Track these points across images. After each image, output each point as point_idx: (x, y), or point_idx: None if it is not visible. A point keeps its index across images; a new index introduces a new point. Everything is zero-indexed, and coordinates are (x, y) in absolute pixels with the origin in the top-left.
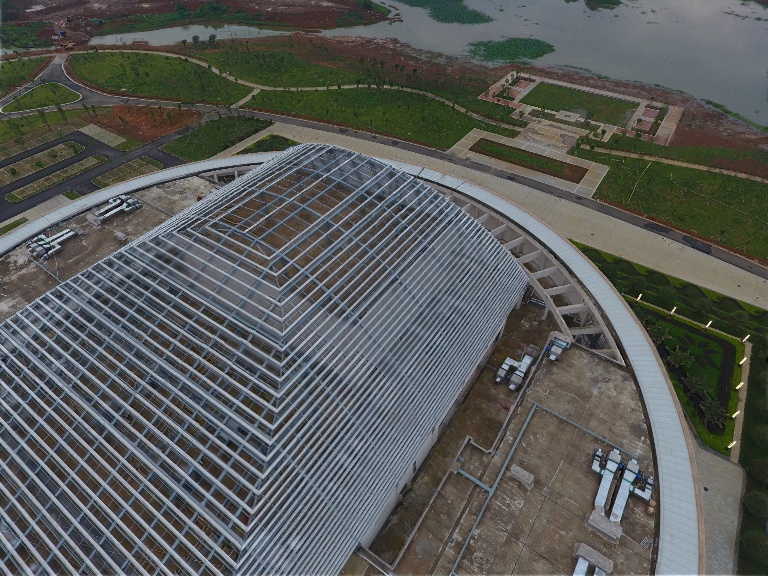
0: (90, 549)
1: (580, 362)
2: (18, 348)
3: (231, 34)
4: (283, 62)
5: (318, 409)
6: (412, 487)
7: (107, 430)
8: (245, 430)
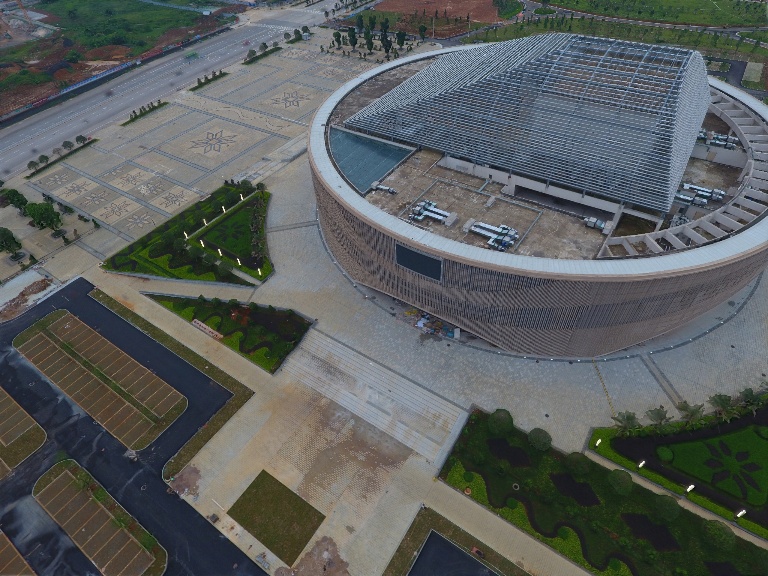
0: None
1: (591, 237)
2: None
3: None
4: None
5: None
6: None
7: None
8: None
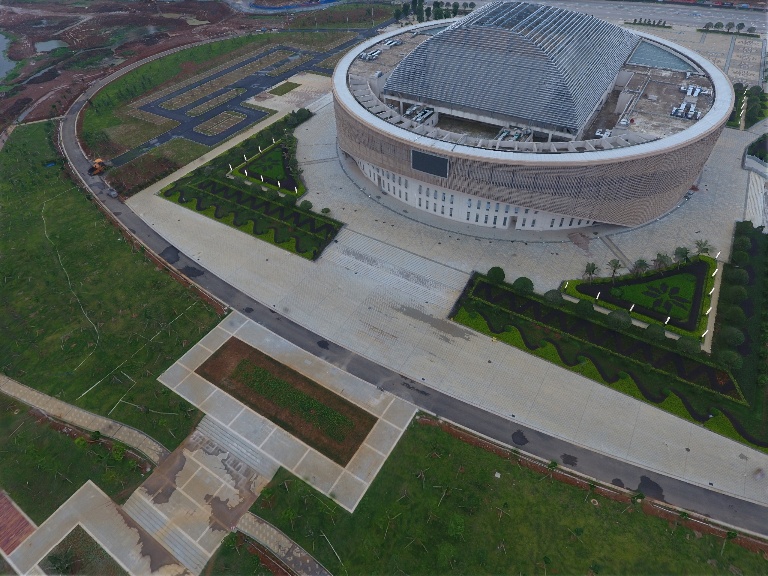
0: None
1: None
2: None
3: None
4: None
5: None
6: None
7: None
8: None
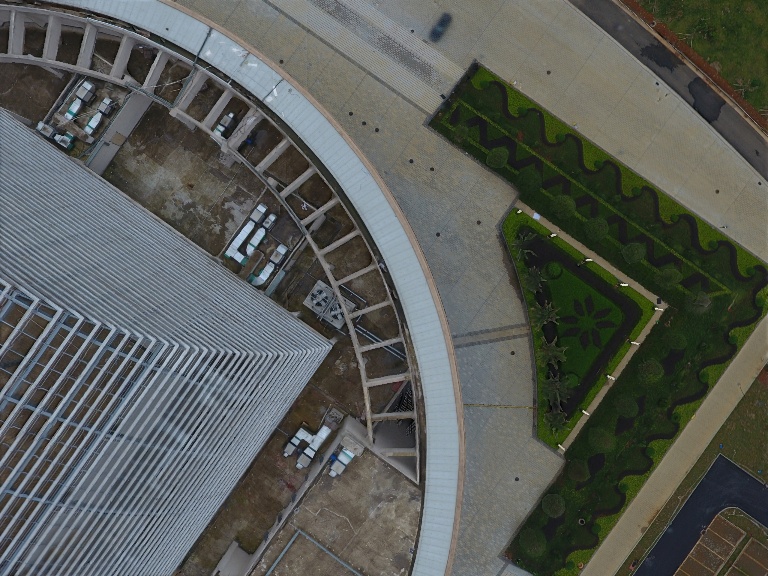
0: None
1: (368, 473)
2: None
3: None
4: None
5: None
6: (182, 568)
7: None
8: None
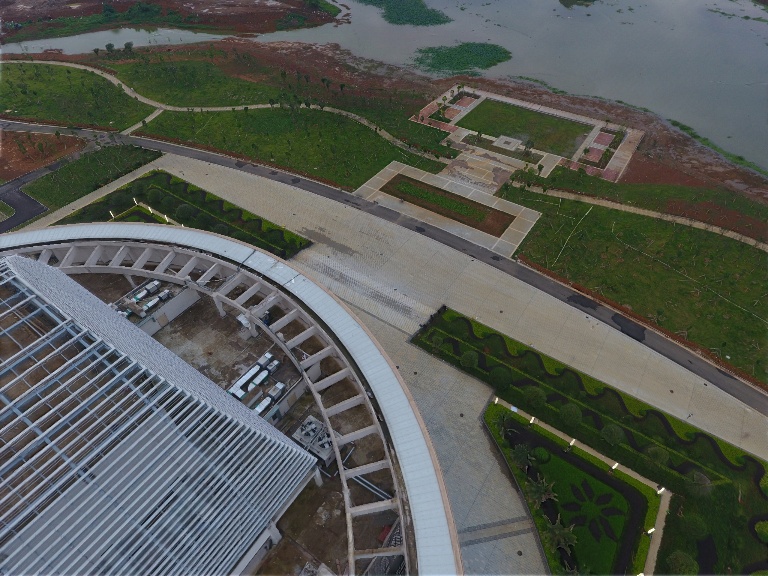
0: None
1: None
2: None
3: (149, 41)
4: (193, 77)
5: None
6: None
7: None
8: None
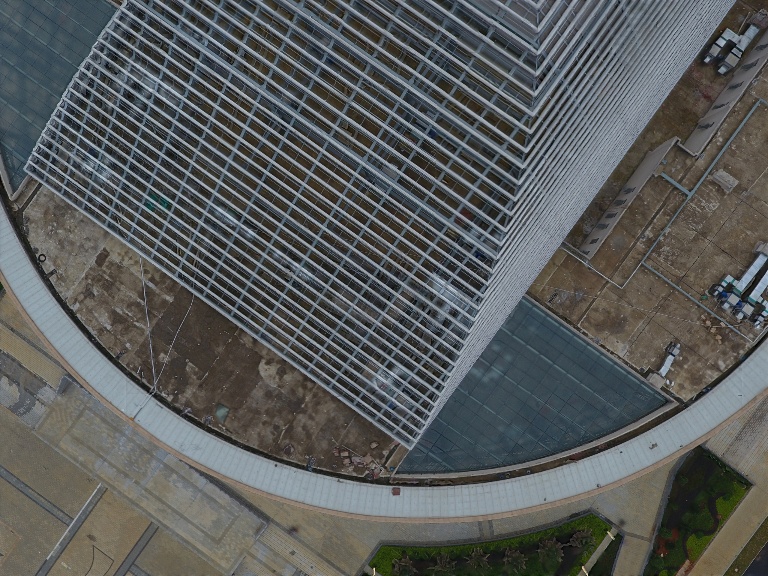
0: (345, 249)
1: None
2: (174, 32)
3: None
4: None
5: (565, 125)
6: None
7: (327, 142)
8: (492, 151)
